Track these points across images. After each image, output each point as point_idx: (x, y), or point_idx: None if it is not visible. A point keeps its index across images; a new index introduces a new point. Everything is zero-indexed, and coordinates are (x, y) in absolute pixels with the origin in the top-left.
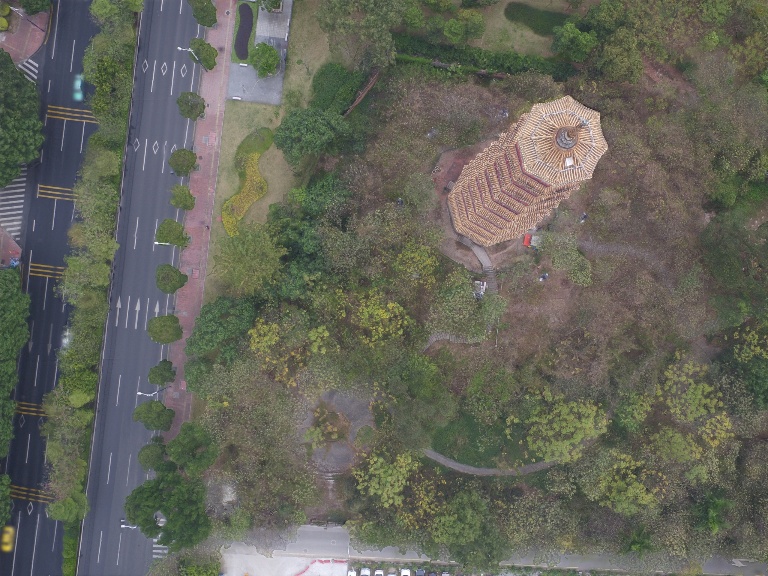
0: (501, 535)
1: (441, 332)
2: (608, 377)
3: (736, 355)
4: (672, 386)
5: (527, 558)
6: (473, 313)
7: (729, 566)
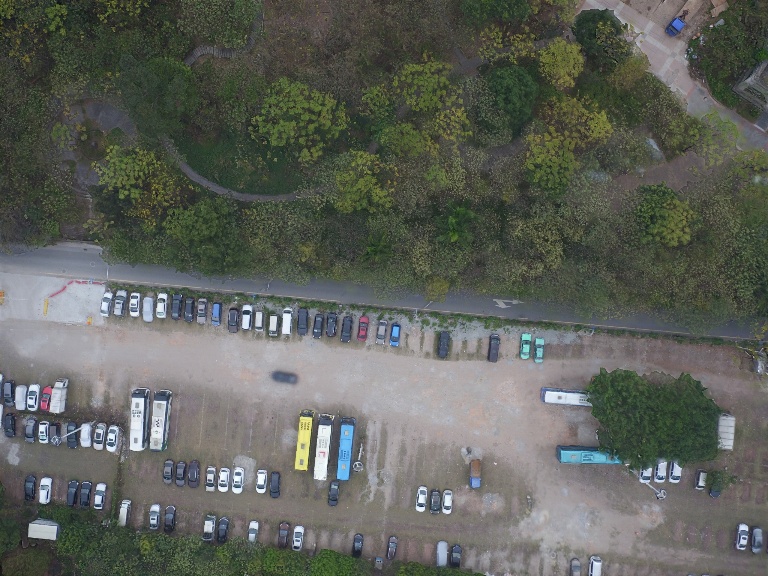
0: (243, 241)
1: (206, 46)
2: (356, 79)
3: (479, 52)
4: (408, 75)
5: (288, 289)
6: (226, 12)
7: (492, 307)
